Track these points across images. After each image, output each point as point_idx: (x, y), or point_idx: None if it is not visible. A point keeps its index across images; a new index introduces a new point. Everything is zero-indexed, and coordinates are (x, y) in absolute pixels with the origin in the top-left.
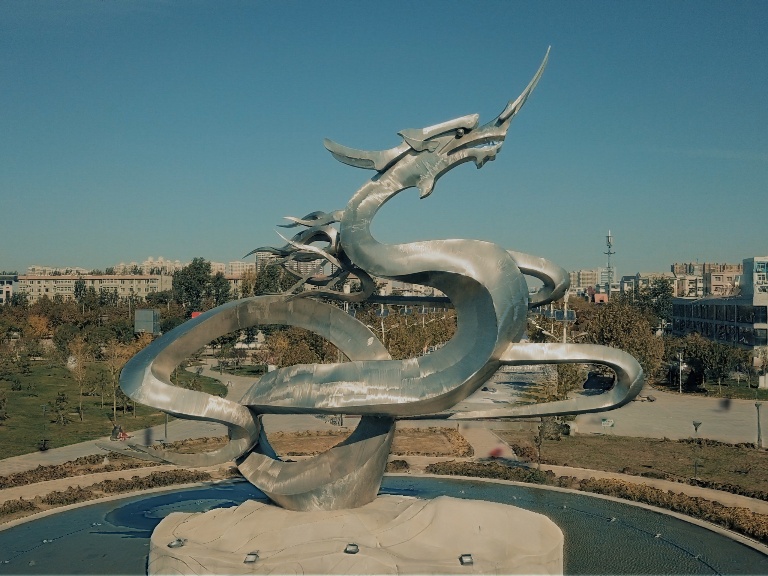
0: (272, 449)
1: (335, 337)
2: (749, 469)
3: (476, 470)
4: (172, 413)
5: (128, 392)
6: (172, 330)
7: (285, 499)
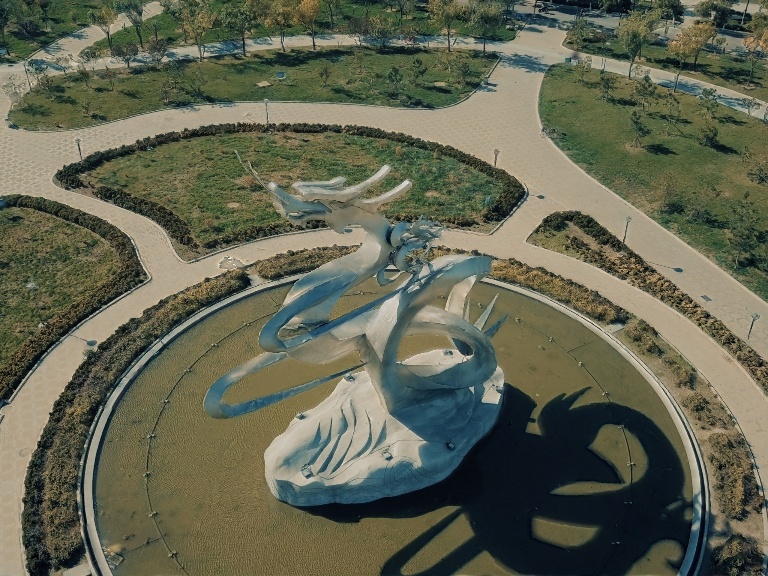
0: (481, 381)
1: None
2: None
3: None
4: None
5: None
6: None
7: None
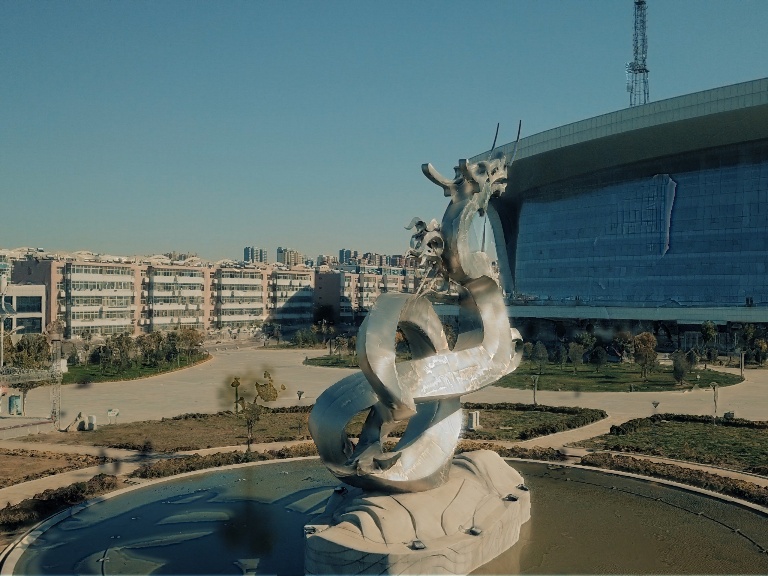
0: None
1: (429, 331)
2: (303, 424)
3: (199, 463)
4: (413, 414)
5: (399, 398)
6: (370, 330)
7: (421, 482)
